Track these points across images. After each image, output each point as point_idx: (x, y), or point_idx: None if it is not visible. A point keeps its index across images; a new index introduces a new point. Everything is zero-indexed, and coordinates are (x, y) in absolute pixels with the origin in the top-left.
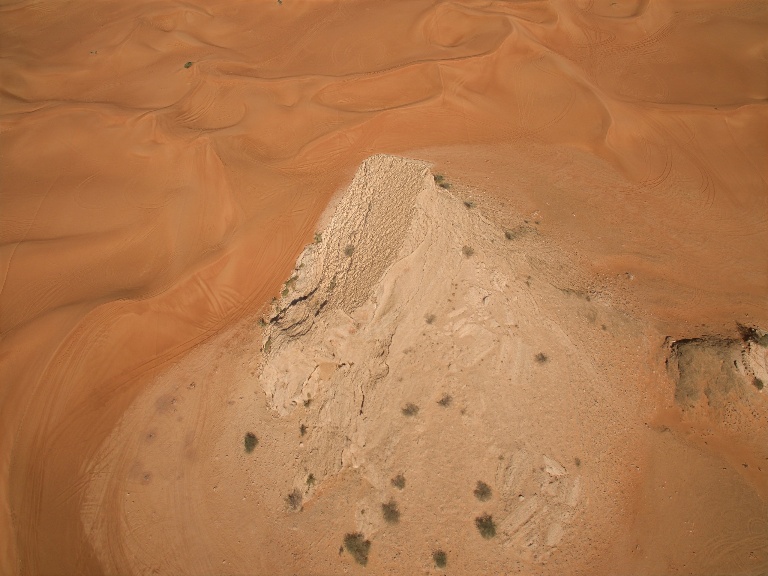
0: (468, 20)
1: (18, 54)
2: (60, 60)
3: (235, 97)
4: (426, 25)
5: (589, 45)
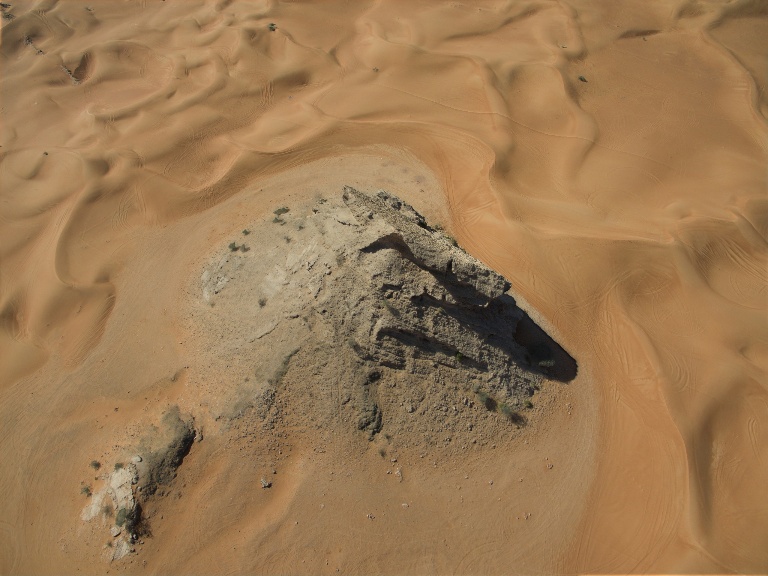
0: None
1: None
2: None
3: None
4: None
5: None
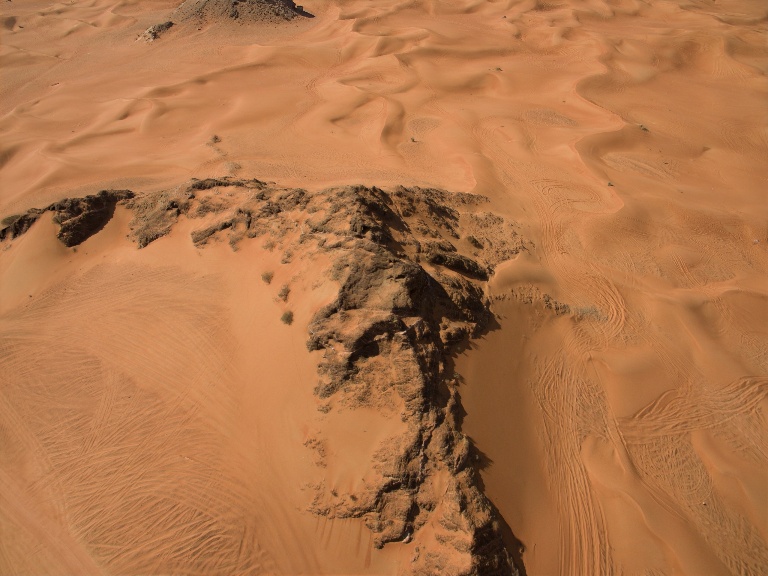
0: None
1: None
2: None
3: None
4: None
5: None
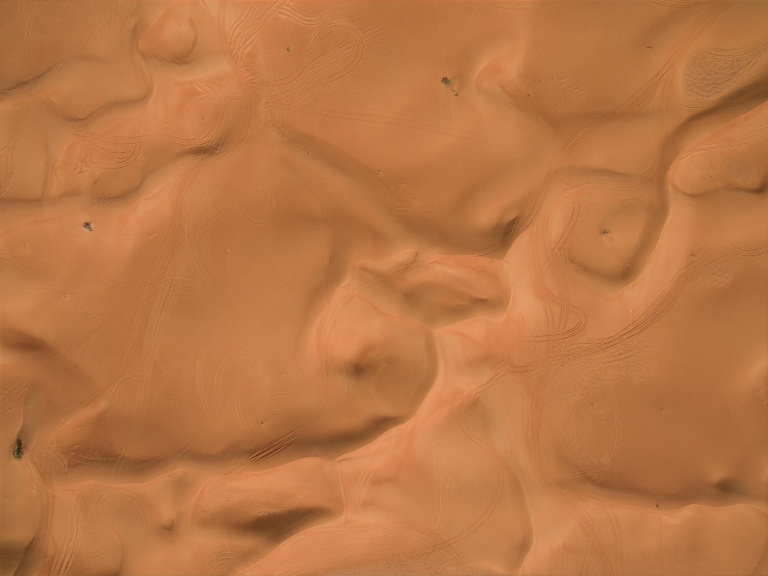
0: (379, 320)
1: None
2: None
3: (100, 516)
4: (319, 333)
5: (547, 338)
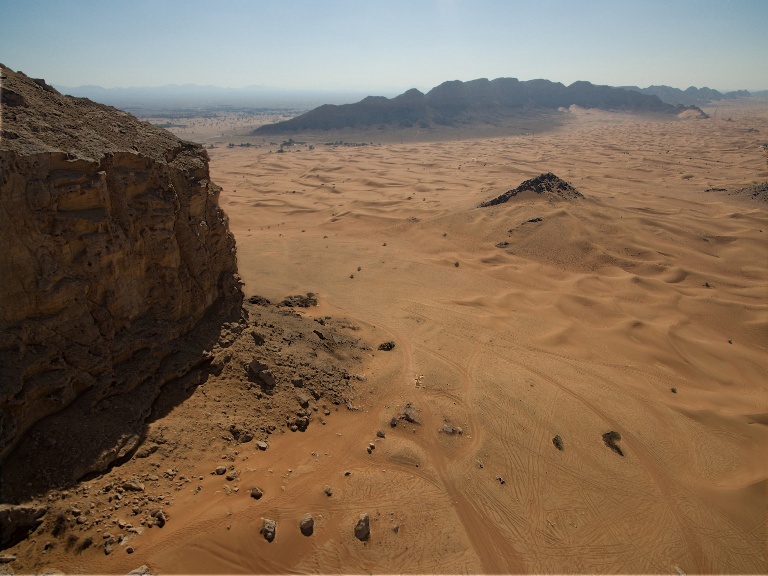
0: None
1: None
2: None
3: None
4: None
5: None
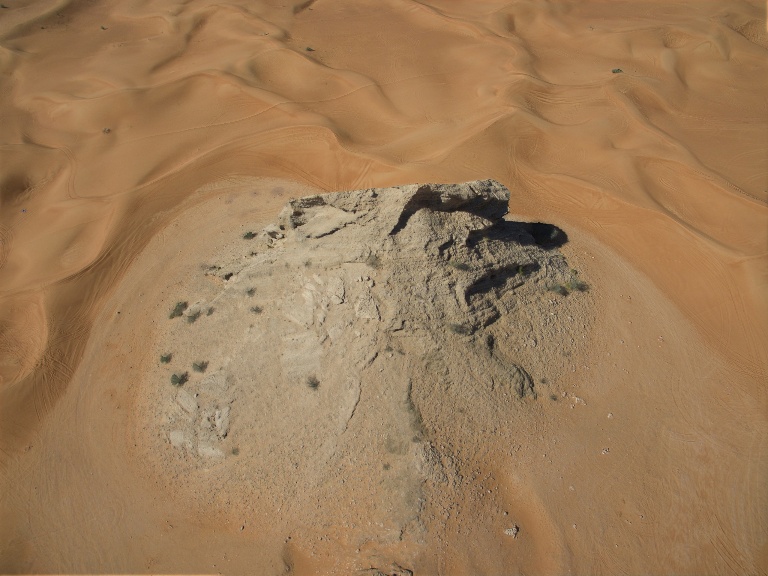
0: None
1: (560, 4)
2: (571, 21)
3: (597, 111)
4: None
5: None
